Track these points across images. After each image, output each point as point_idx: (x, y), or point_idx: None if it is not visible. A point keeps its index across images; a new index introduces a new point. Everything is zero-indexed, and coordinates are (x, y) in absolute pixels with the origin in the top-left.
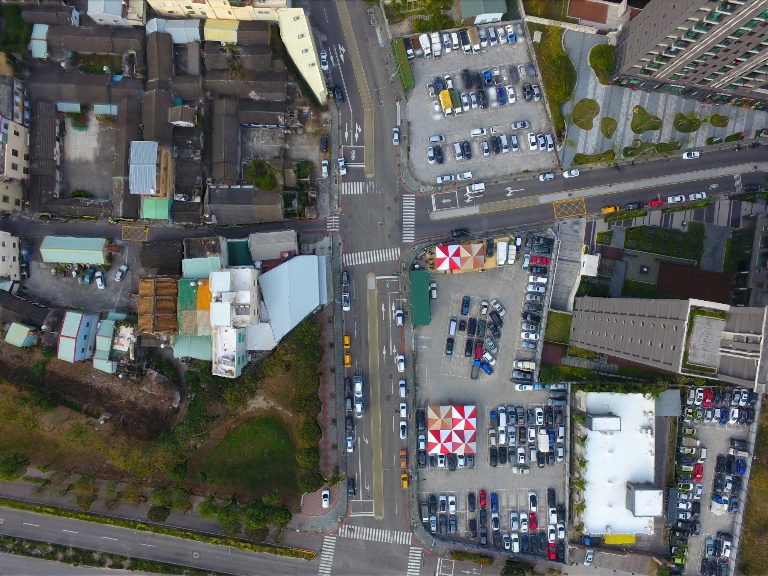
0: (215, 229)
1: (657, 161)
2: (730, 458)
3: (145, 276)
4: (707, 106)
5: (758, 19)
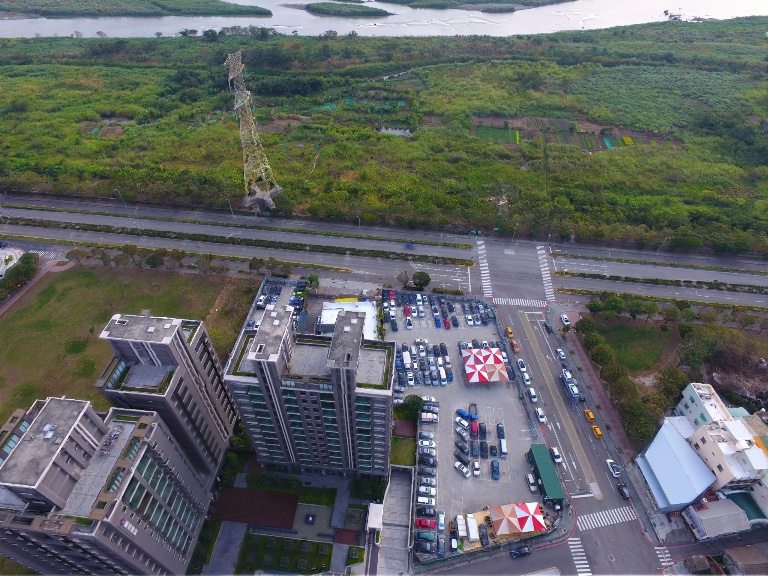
0: None
1: None
2: None
3: None
4: None
5: None
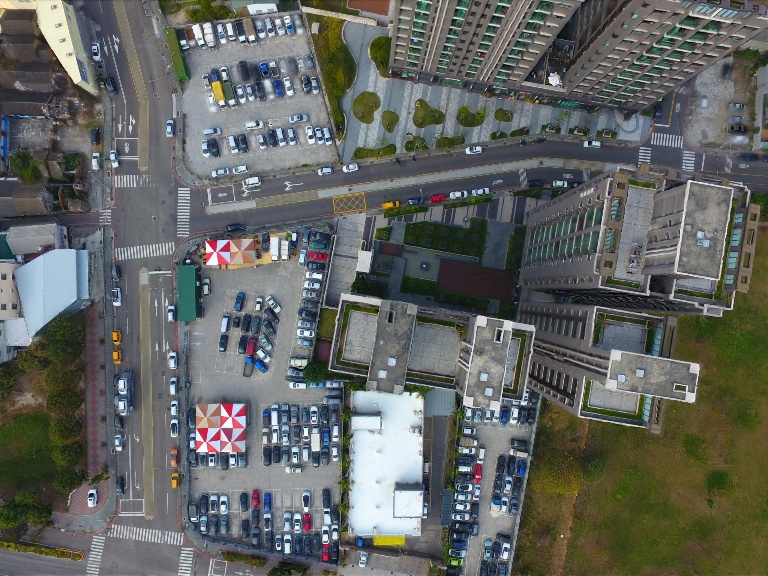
0: None
1: (440, 156)
2: (510, 458)
3: None
4: (491, 100)
5: (461, 8)
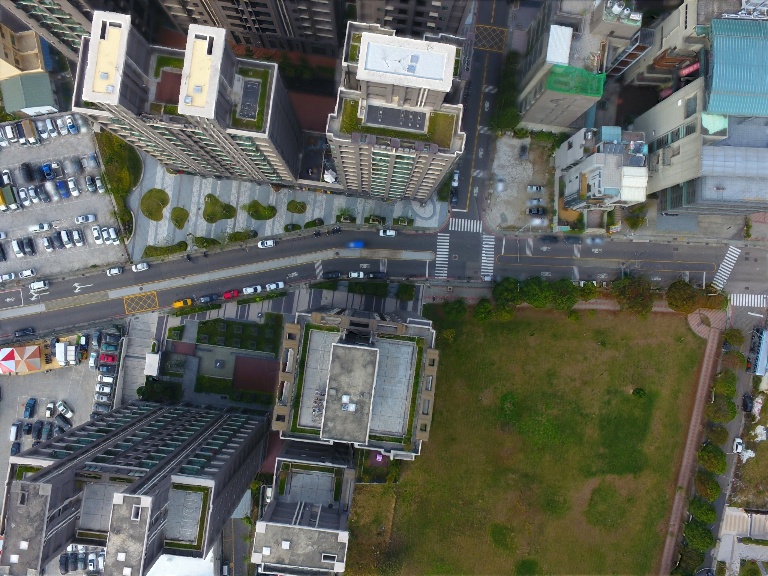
0: None
1: (232, 251)
2: None
3: None
4: (283, 192)
5: (169, 137)
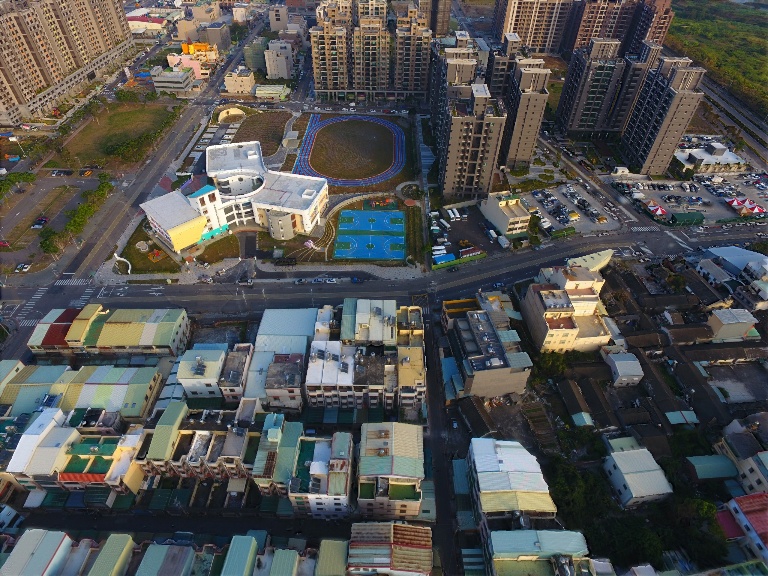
0: None
1: None
2: None
3: None
4: None
5: None
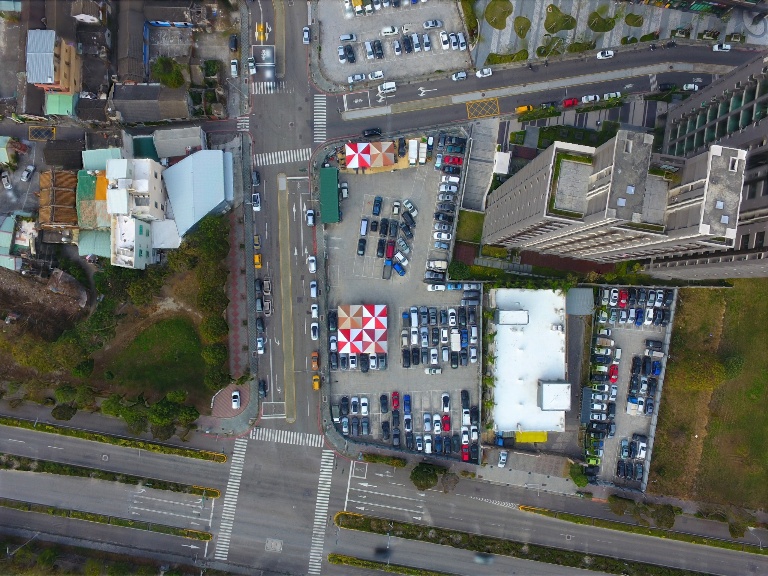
0: (122, 128)
1: (571, 61)
2: (645, 359)
3: (47, 170)
4: (621, 5)
5: None
